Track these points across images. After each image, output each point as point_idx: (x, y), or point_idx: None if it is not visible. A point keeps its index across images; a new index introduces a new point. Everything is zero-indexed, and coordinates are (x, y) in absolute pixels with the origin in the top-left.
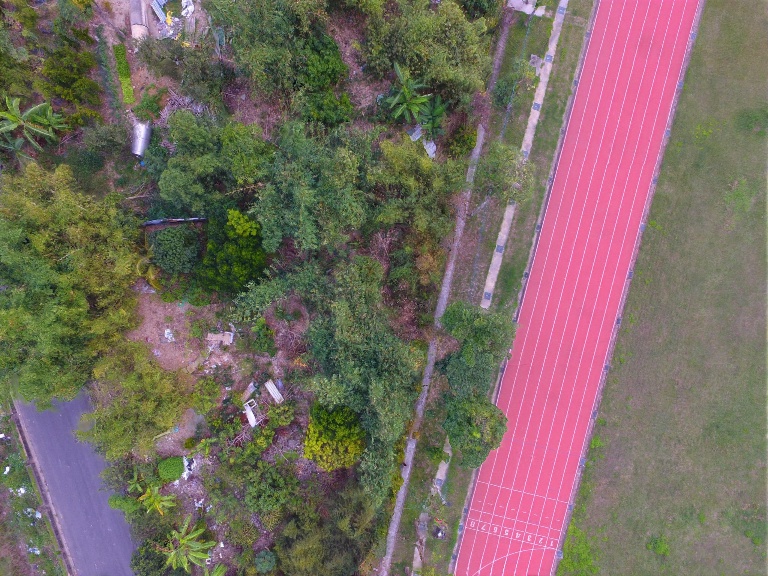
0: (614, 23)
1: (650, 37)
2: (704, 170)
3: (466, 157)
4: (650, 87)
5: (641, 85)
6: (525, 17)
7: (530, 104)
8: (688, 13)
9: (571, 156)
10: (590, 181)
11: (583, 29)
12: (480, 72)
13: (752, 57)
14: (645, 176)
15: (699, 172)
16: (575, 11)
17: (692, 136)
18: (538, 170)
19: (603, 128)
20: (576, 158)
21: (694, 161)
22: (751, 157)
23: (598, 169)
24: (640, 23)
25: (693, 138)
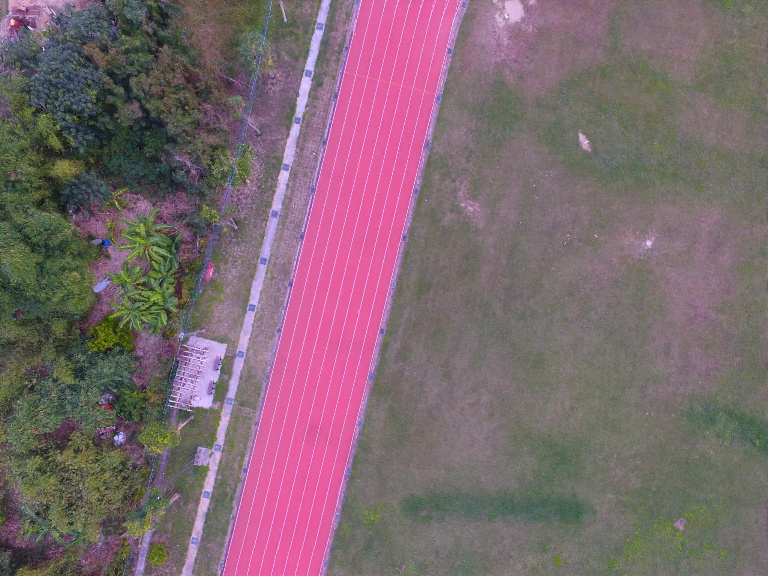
0: (281, 413)
1: (317, 425)
2: (373, 554)
3: (136, 546)
4: (318, 474)
5: (309, 472)
6: (192, 410)
7: (199, 493)
8: (354, 402)
9: (241, 542)
10: (261, 566)
11: (251, 419)
12: (117, 501)
13: (417, 444)
14: (316, 560)
15: (368, 556)
16: (242, 402)
17: (360, 521)
18: (208, 557)
19: (273, 514)
20: (246, 544)
21: (363, 545)
22: (418, 541)
23: (269, 554)
24: (307, 412)
25: (361, 523)
